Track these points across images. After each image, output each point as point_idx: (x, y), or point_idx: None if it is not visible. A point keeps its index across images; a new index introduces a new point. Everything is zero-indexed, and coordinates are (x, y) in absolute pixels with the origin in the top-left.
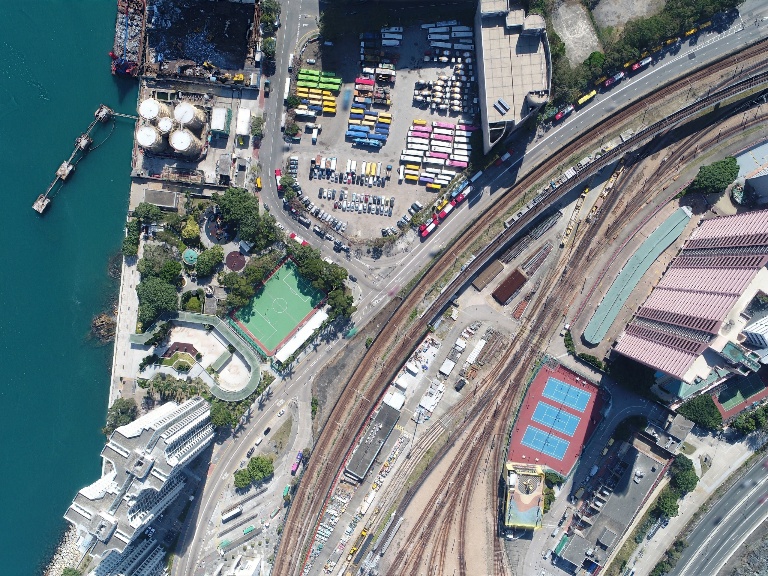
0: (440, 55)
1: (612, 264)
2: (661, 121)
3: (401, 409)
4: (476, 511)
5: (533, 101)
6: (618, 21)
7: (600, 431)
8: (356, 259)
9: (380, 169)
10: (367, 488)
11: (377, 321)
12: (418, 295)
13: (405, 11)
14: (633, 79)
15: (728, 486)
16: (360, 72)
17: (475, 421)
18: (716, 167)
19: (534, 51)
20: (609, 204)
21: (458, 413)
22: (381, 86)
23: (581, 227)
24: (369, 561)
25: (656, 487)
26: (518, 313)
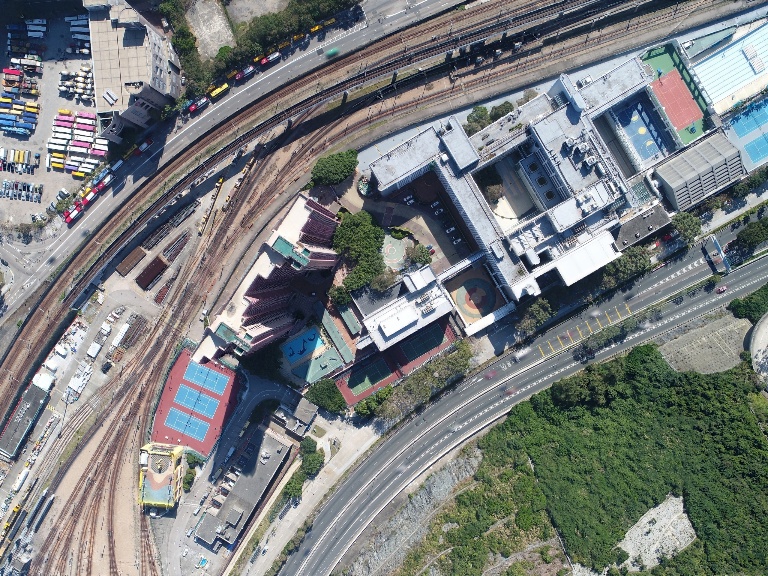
0: (83, 47)
1: (247, 252)
2: (279, 114)
3: (52, 390)
4: (124, 489)
5: (130, 92)
6: (251, 17)
7: (238, 414)
8: (8, 244)
9: (28, 157)
10: (21, 466)
11: (28, 304)
12: (66, 279)
13: (52, 4)
14: (266, 73)
15: (354, 468)
16: (10, 62)
17: (121, 402)
18: (330, 159)
19: (140, 44)
20: (244, 194)
21: (105, 394)
22: (30, 76)
23: (218, 216)
24: (24, 537)
25: (290, 468)
26: (159, 298)
